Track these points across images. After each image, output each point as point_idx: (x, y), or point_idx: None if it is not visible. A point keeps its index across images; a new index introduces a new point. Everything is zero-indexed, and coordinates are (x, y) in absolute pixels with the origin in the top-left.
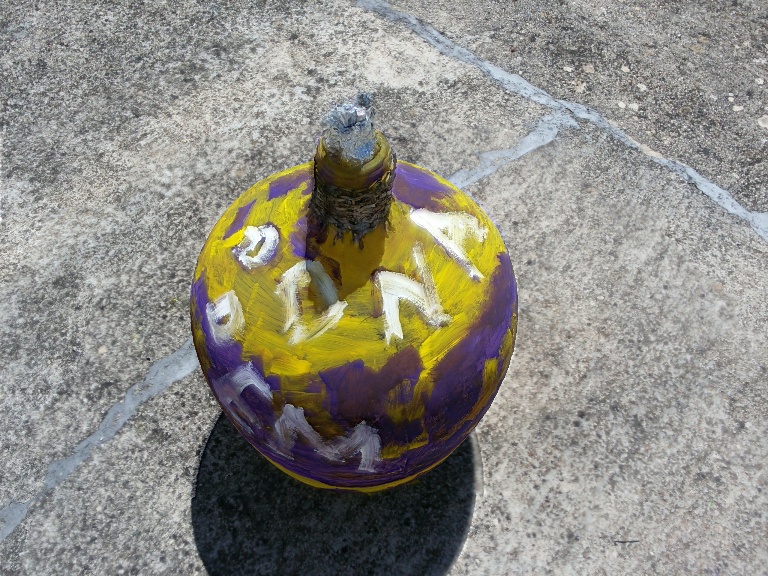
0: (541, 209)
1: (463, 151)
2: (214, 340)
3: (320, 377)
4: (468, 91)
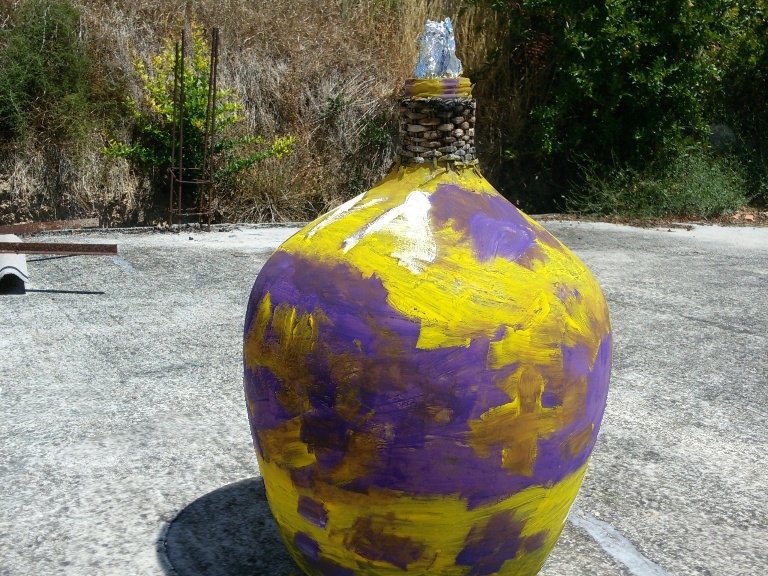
0: None
1: None
2: None
3: None
4: None
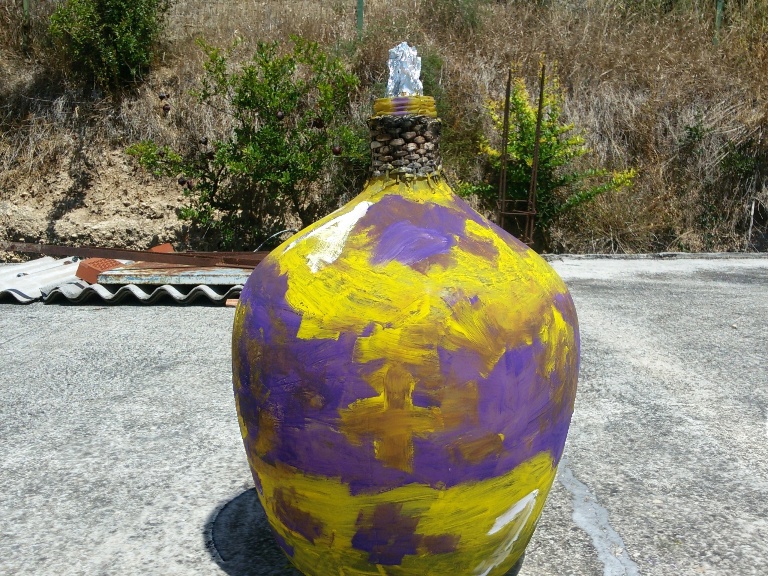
0: None
1: None
2: None
3: None
4: None
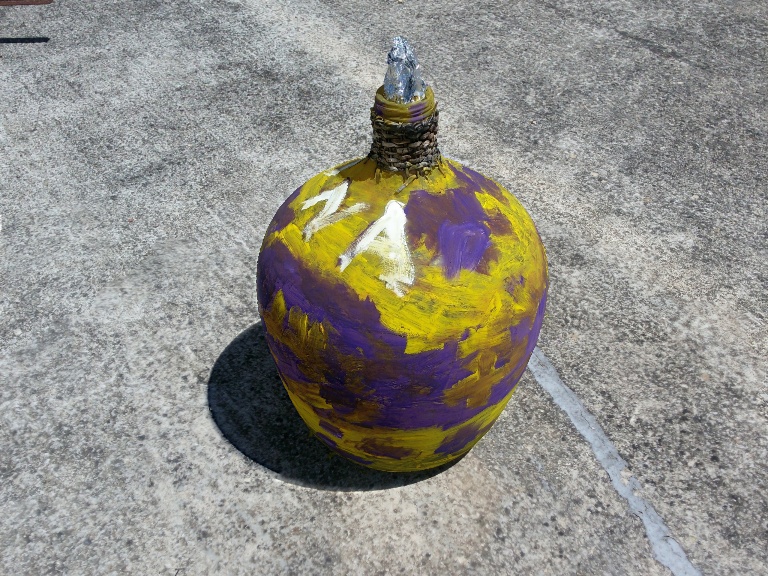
0: None
1: None
2: None
3: None
4: None
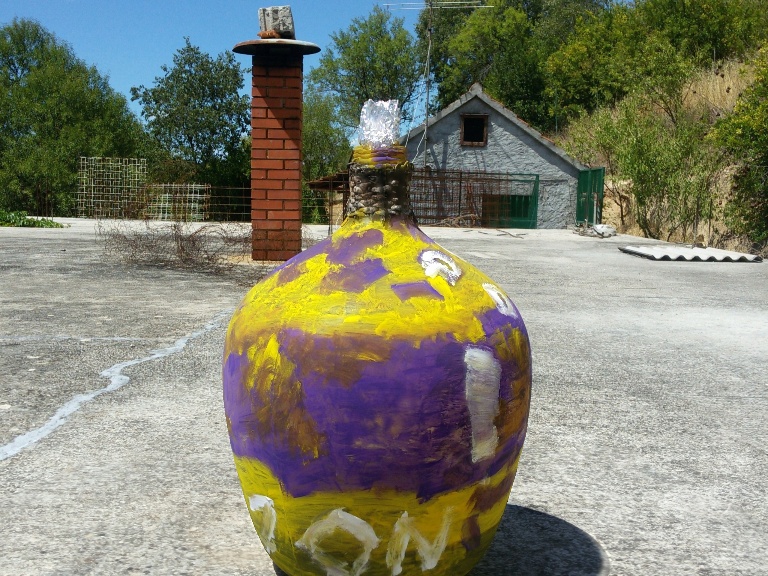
0: (8, 546)
1: None
2: (517, 318)
3: None
4: None
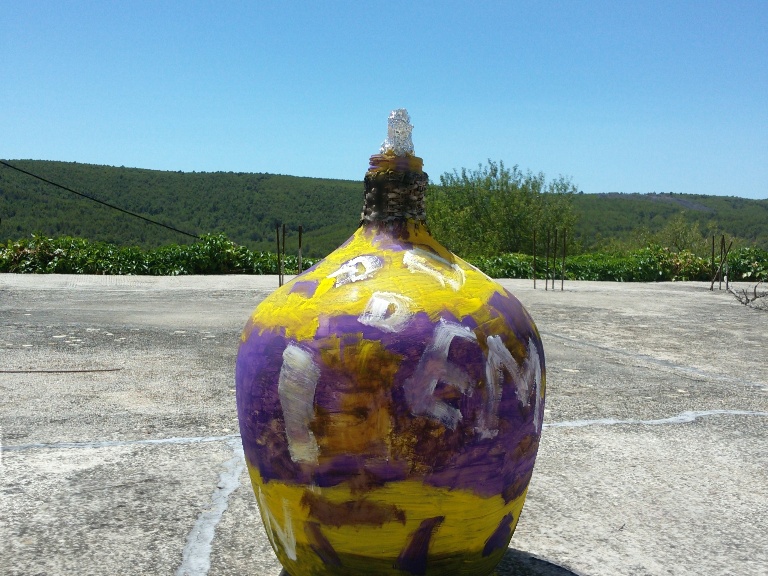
0: None
1: (204, 469)
2: (393, 332)
3: (490, 306)
4: (152, 452)
